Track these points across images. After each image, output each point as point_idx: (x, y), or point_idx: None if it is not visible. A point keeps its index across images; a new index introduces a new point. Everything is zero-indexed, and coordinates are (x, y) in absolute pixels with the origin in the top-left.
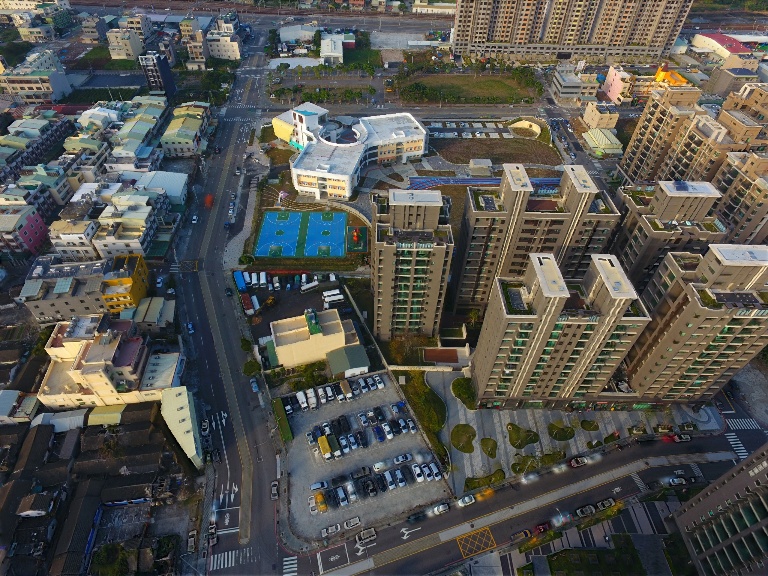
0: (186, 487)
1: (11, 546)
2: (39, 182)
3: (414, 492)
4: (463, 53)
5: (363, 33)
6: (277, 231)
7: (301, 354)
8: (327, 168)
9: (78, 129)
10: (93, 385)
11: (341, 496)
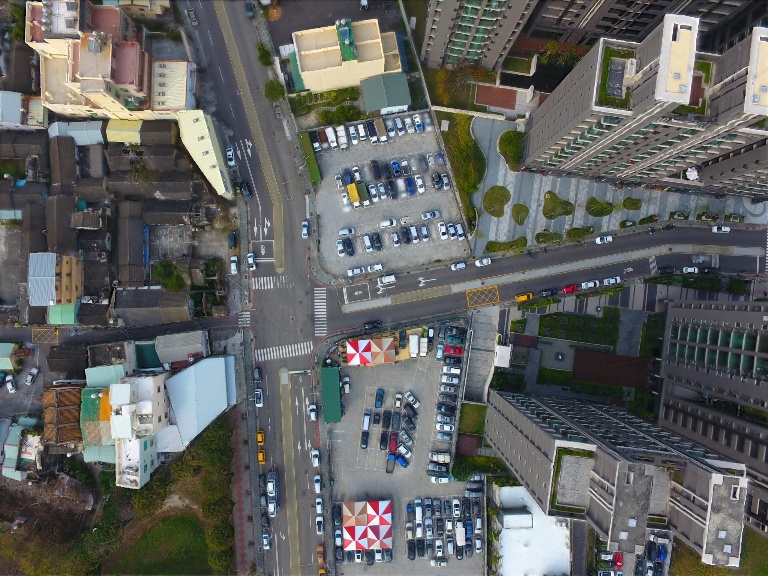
0: (221, 217)
1: (78, 252)
2: None
3: (436, 248)
4: None
5: None
6: None
7: (331, 80)
8: None
9: None
10: (99, 102)
11: (367, 244)
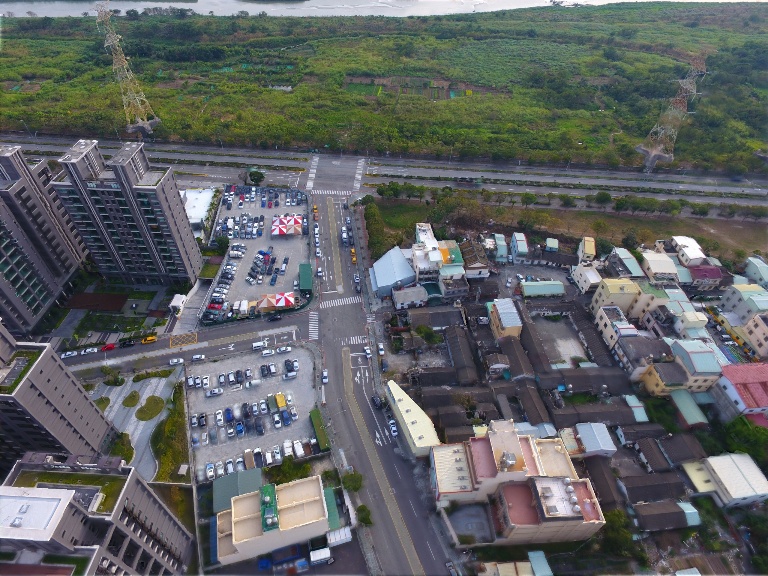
0: (396, 380)
1: None
2: None
3: (215, 370)
4: None
5: None
6: None
7: None
8: None
9: None
10: None
11: (273, 366)
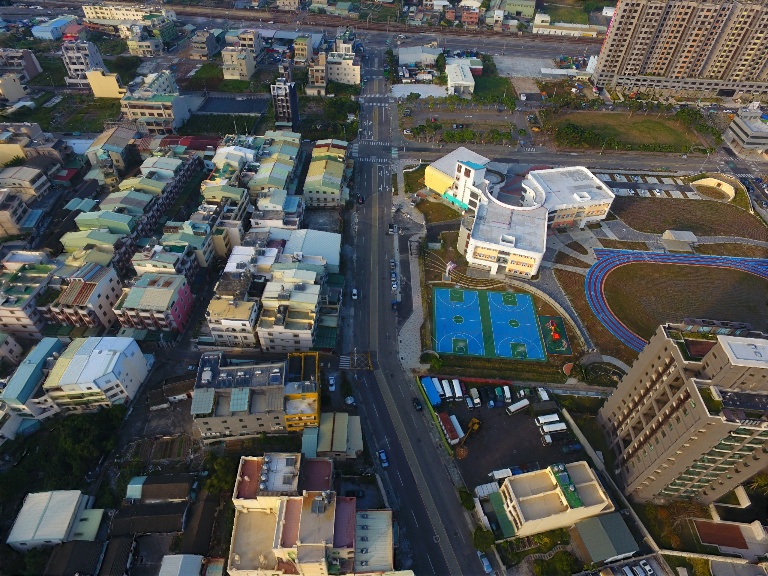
0: None
1: None
2: (186, 243)
3: None
4: (606, 85)
5: (484, 56)
6: (455, 317)
7: (546, 524)
8: (511, 240)
9: (206, 166)
10: (304, 569)
11: None
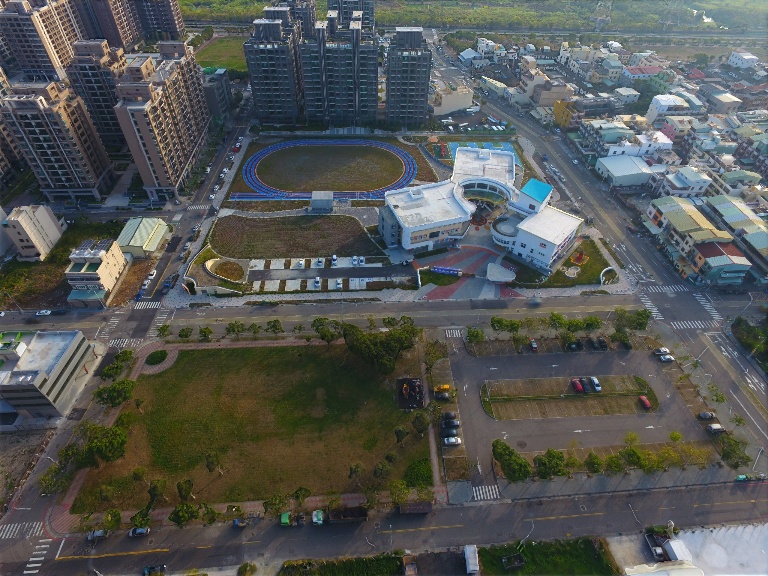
0: None
1: None
2: None
3: None
4: None
5: None
6: None
7: None
8: (482, 158)
9: None
10: None
11: None
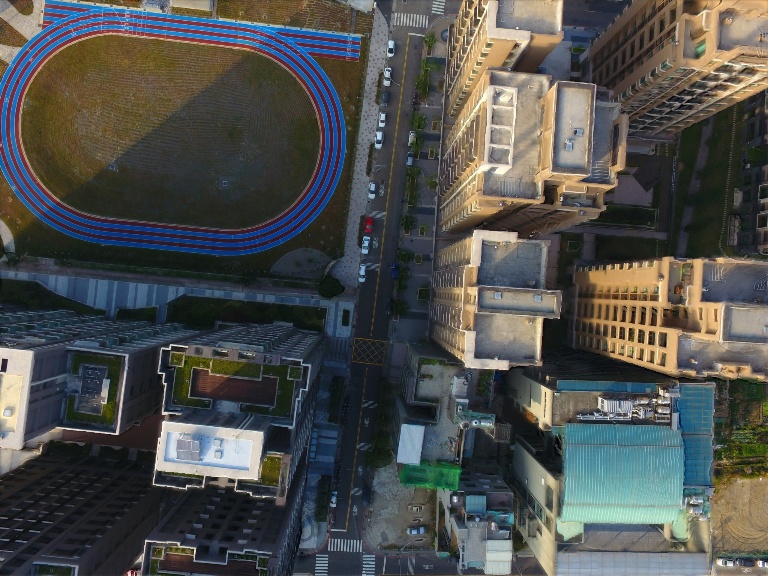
0: None
1: None
2: None
3: None
4: None
5: None
6: None
7: None
8: None
9: None
10: None
11: None
